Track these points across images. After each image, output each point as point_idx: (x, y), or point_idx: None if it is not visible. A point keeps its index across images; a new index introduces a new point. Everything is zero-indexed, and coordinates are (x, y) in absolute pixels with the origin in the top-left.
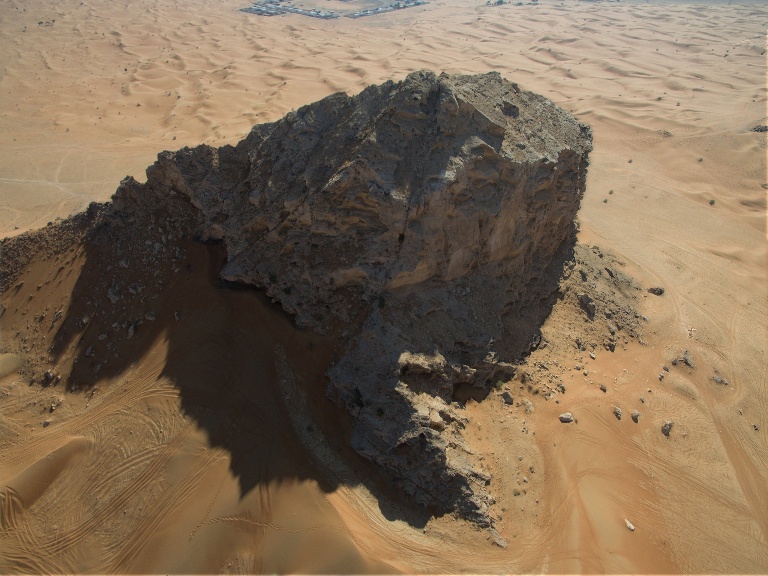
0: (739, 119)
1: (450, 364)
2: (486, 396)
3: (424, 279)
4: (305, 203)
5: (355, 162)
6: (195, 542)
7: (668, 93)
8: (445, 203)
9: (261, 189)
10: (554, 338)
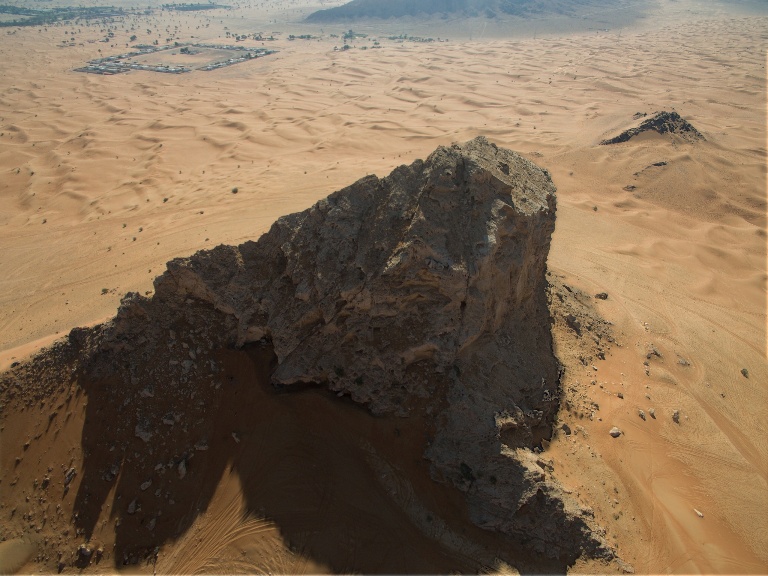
0: (586, 136)
1: (526, 413)
2: (552, 433)
3: (476, 338)
4: (365, 290)
5: (413, 242)
6: None
7: (522, 119)
8: (491, 265)
9: (309, 283)
10: (566, 361)
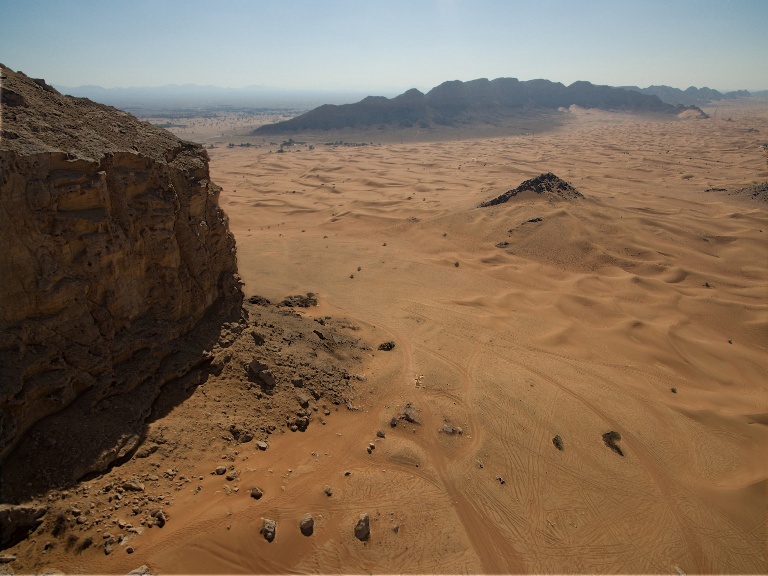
0: (469, 201)
1: None
2: None
3: None
4: None
5: None
6: None
7: (417, 194)
8: None
9: None
10: (182, 434)
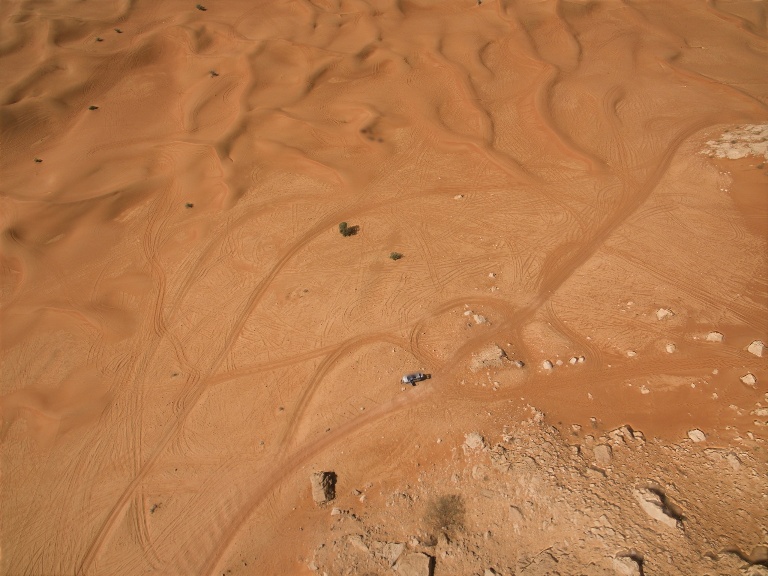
0: None
1: None
2: None
3: None
4: None
5: None
6: None
7: None
8: None
9: None
10: None
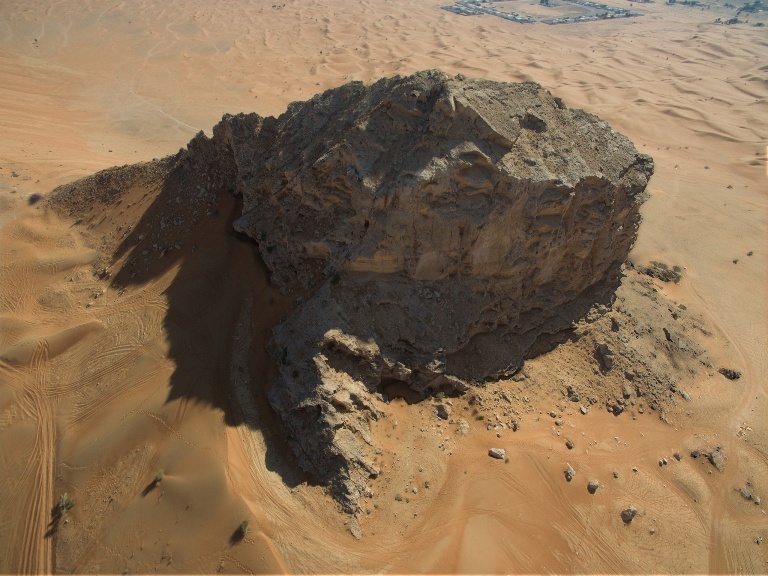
0: None
1: (383, 356)
2: (419, 401)
3: (392, 271)
4: (298, 175)
5: (340, 145)
6: (124, 423)
7: None
8: (417, 201)
9: (275, 157)
10: (540, 376)
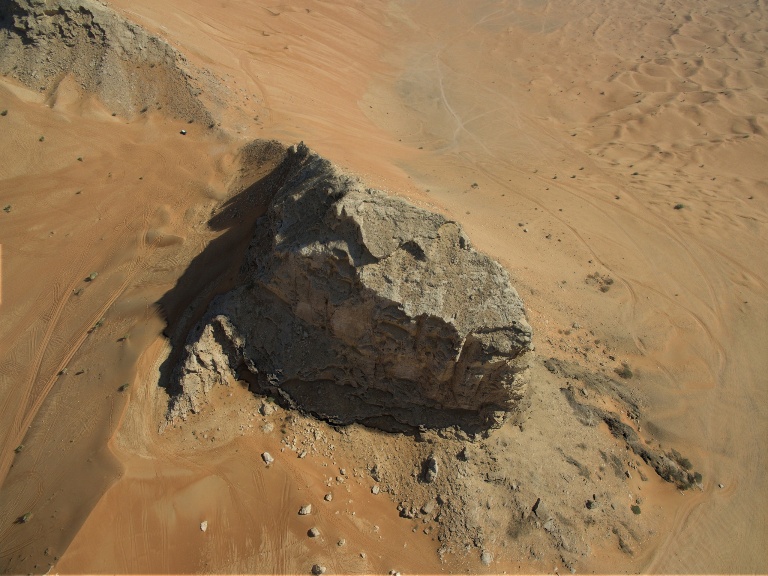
0: None
1: (245, 350)
2: (256, 393)
3: None
4: None
5: None
6: None
7: None
8: (298, 265)
9: None
10: (360, 441)
